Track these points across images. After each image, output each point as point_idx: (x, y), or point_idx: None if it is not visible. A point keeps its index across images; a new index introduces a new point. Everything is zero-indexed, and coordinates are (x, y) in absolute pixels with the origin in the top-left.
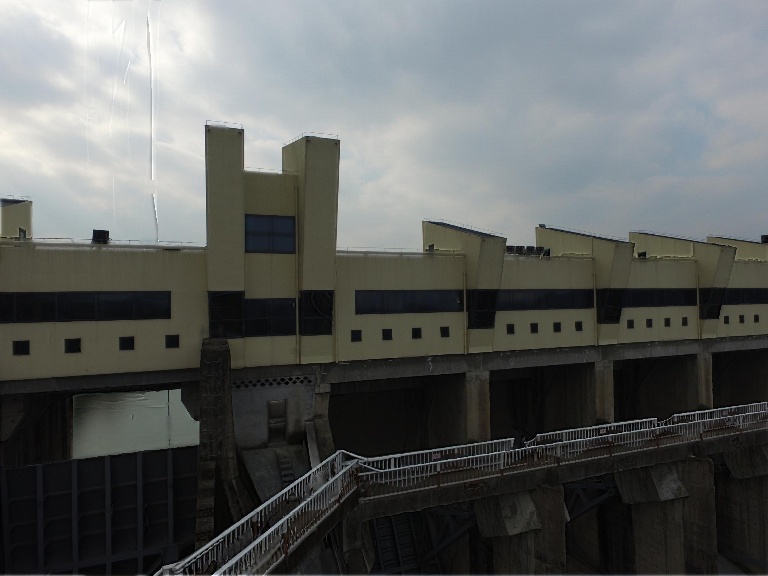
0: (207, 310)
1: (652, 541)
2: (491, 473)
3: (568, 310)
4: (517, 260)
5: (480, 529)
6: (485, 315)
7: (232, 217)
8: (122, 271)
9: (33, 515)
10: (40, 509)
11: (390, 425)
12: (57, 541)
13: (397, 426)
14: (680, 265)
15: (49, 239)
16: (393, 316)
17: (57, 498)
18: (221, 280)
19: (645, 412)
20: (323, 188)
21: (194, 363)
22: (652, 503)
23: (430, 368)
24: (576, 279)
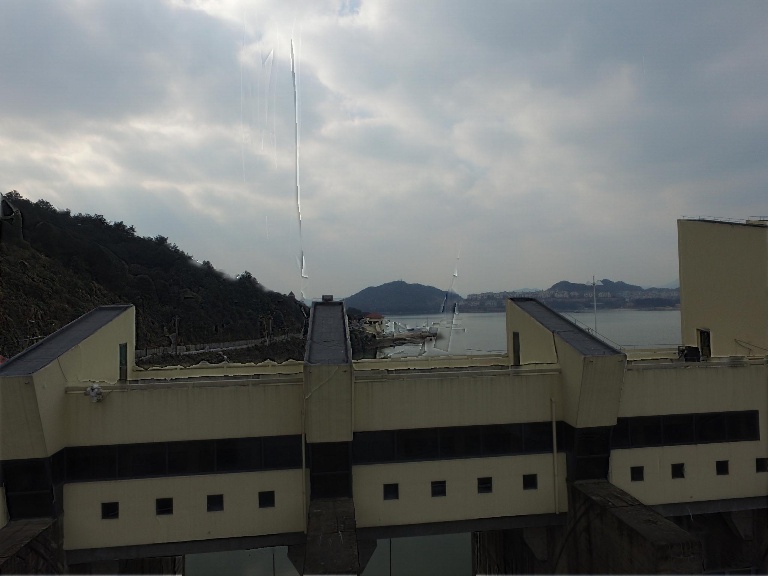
0: None
1: None
2: None
3: None
4: None
5: None
6: None
7: None
8: (715, 390)
9: None
10: None
11: None
12: None
13: None
14: None
15: (653, 360)
16: None
17: None
18: None
19: None
20: None
21: None
22: None
23: None
24: None
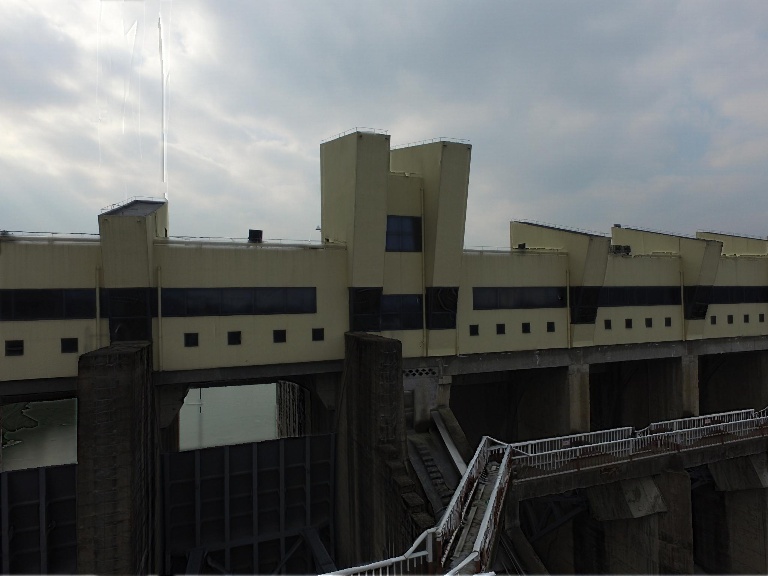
0: (347, 305)
1: (749, 527)
2: (622, 458)
3: (658, 306)
4: (613, 258)
5: (596, 513)
6: (587, 311)
7: (376, 218)
8: (275, 268)
9: (191, 497)
10: (198, 491)
11: (473, 418)
12: (208, 522)
13: (479, 419)
14: (757, 263)
15: (213, 238)
16: (505, 311)
17: (209, 482)
18: (364, 277)
19: (714, 406)
20: (455, 190)
21: (337, 355)
22: (749, 490)
23: (537, 361)
24: (665, 277)
